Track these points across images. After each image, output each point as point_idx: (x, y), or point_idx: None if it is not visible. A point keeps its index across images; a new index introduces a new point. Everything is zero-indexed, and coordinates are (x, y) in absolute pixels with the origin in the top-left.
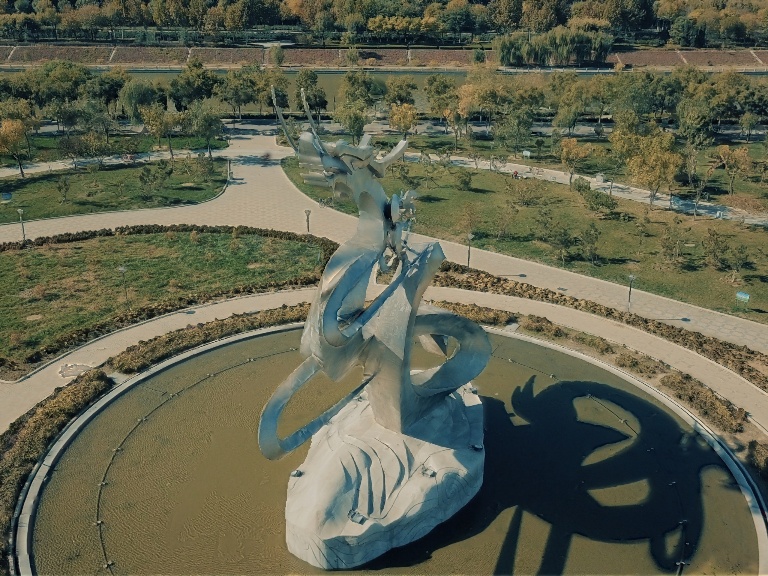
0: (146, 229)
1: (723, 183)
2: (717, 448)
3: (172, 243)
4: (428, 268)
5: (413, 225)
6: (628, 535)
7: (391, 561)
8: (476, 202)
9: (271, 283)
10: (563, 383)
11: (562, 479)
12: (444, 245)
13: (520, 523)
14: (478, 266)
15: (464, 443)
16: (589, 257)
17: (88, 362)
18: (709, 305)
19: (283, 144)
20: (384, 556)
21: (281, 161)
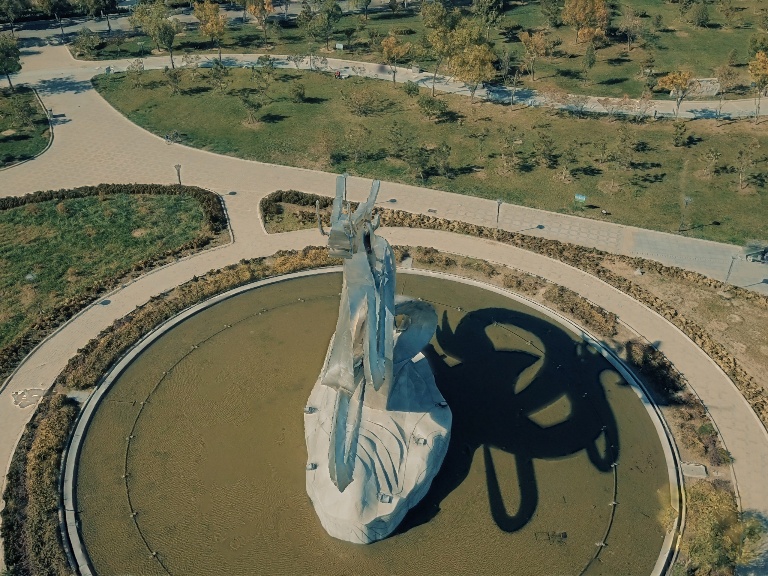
0: (1, 205)
1: (520, 61)
2: (605, 354)
3: (40, 219)
4: (394, 274)
5: (270, 154)
6: (570, 450)
7: (412, 521)
8: (317, 116)
9: (168, 252)
10: (471, 314)
11: (501, 407)
12: (309, 175)
13: (492, 460)
14: (350, 196)
15: (430, 402)
16: (443, 172)
17: (37, 385)
18: (553, 208)
19: (81, 57)
20: (406, 519)
21: (92, 83)
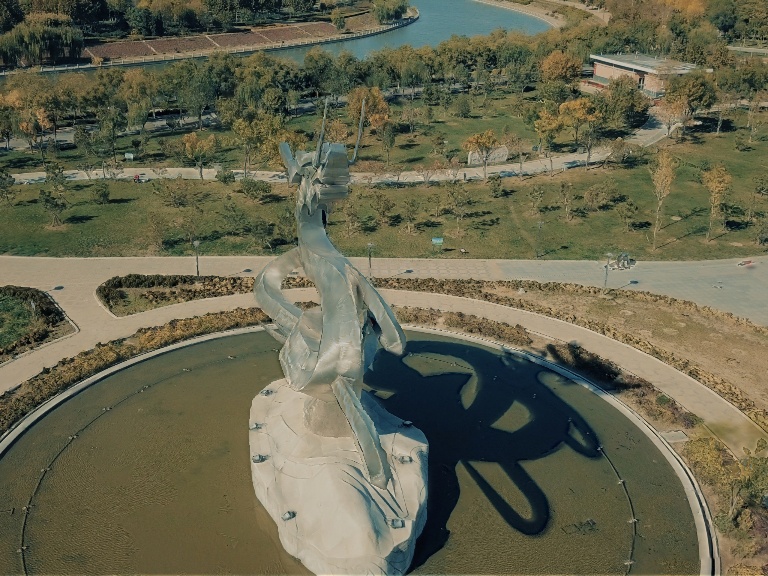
0: None
1: None
2: (533, 359)
3: None
4: None
5: (89, 250)
6: (549, 445)
7: (425, 551)
8: (129, 213)
9: None
10: (381, 351)
11: (455, 427)
12: (143, 262)
13: (477, 472)
14: (199, 273)
15: (391, 426)
16: None
17: None
18: (413, 255)
19: None
20: (417, 550)
21: None
